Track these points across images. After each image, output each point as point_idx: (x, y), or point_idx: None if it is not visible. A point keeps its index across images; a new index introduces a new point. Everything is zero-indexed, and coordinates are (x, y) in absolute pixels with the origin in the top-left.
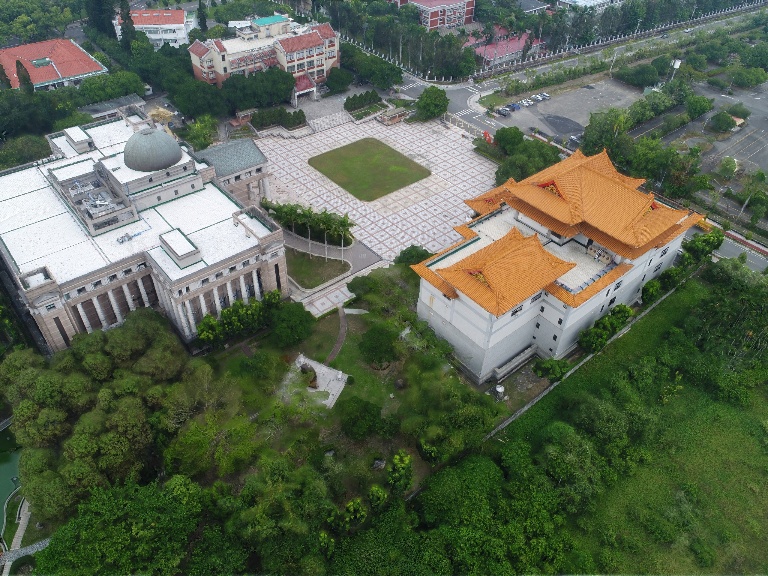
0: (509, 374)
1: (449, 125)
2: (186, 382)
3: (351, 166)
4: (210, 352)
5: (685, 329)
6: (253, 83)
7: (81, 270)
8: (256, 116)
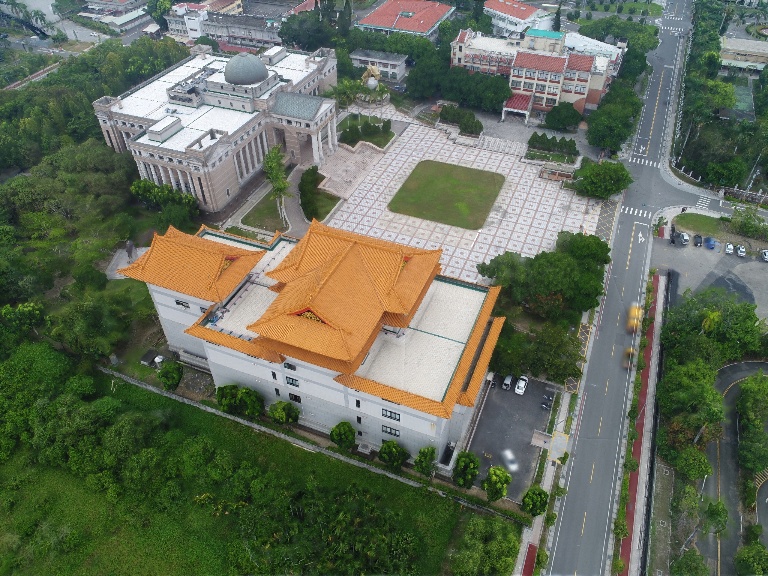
0: (190, 366)
1: (594, 211)
2: None
3: (438, 182)
4: (151, 209)
5: (327, 501)
6: (468, 80)
7: (133, 113)
8: (443, 108)
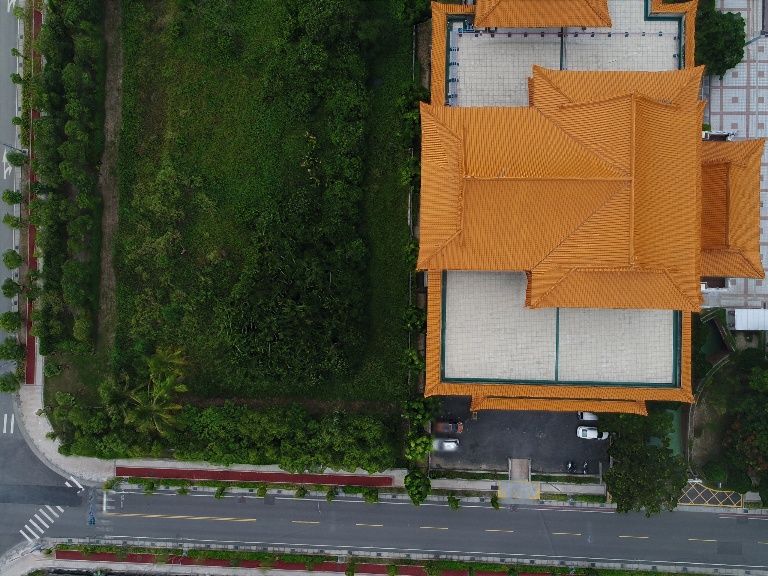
0: None
1: None
2: None
3: None
4: None
5: (352, 267)
6: None
7: None
8: None
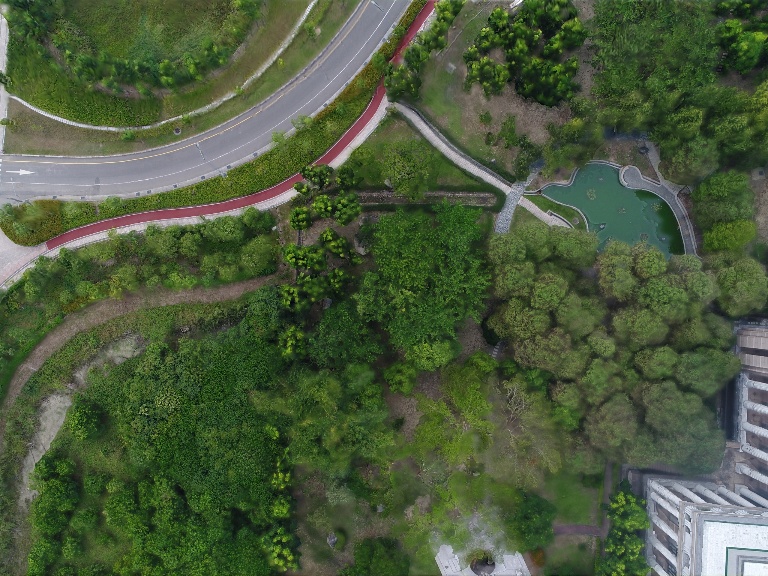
0: None
1: None
2: (565, 436)
3: None
4: None
5: None
6: None
7: None
8: None
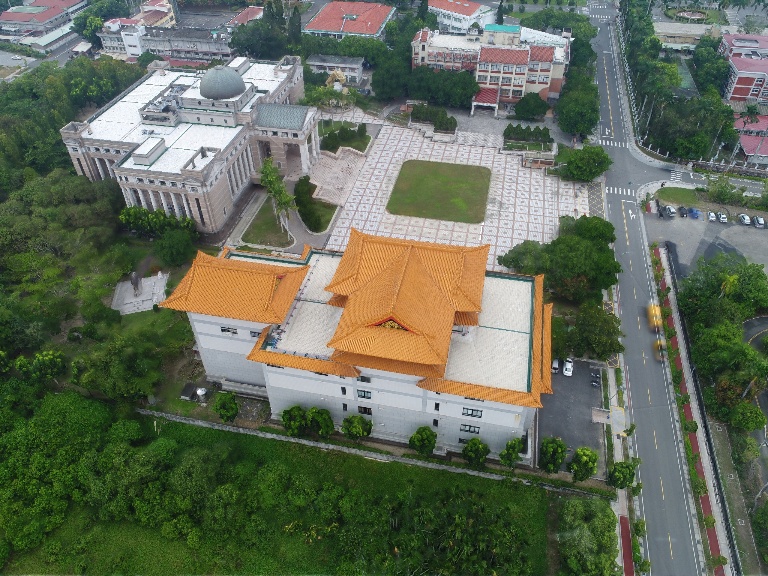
0: (235, 394)
1: (582, 194)
2: None
3: (428, 181)
4: None
5: None
6: (435, 78)
7: (106, 137)
8: (414, 107)
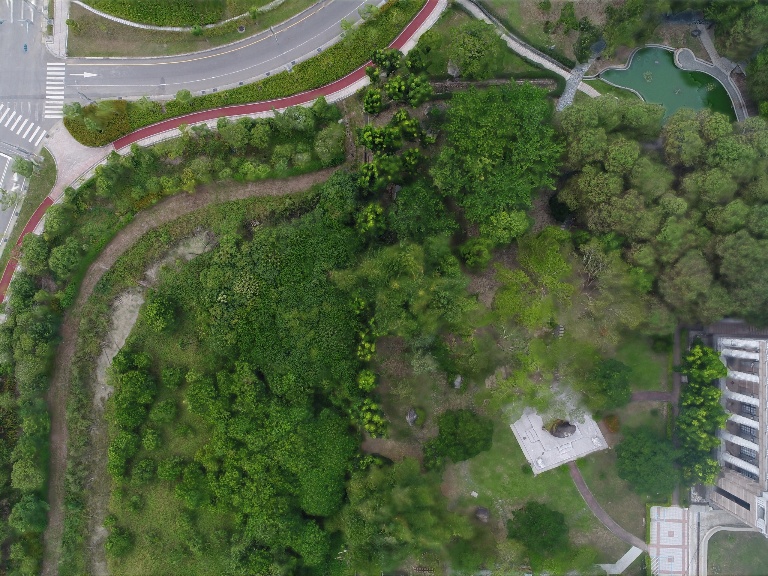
0: None
1: None
2: (640, 296)
3: None
4: None
5: None
6: None
7: None
8: None
